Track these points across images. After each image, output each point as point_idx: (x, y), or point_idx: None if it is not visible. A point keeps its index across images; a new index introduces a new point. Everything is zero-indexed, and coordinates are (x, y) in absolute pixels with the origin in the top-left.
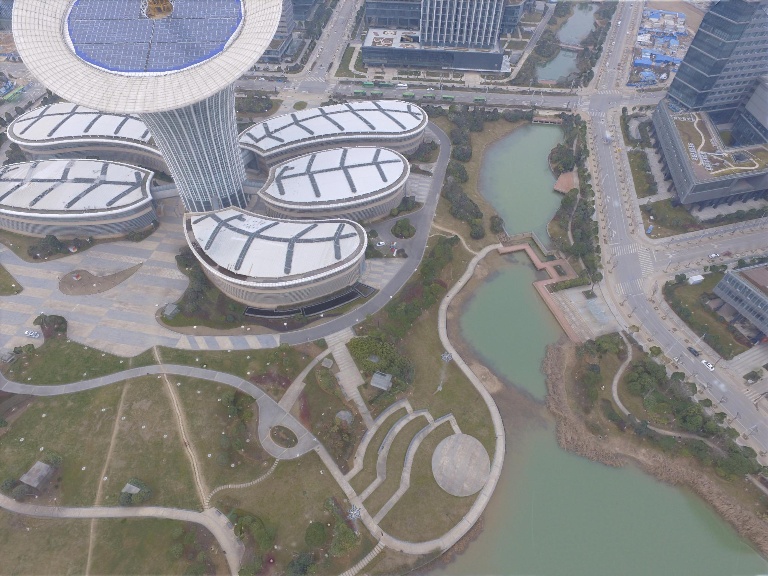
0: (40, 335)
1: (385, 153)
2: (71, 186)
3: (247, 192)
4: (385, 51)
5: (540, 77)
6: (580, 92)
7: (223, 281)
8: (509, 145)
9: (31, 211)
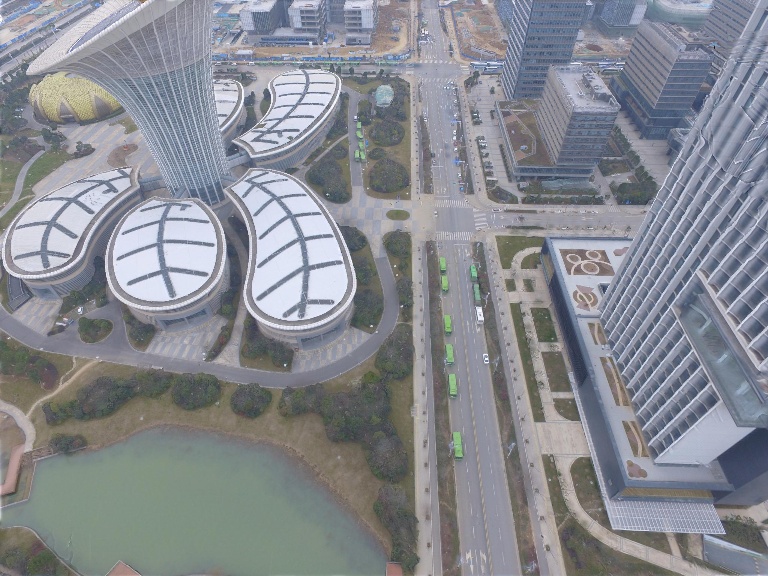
0: (78, 151)
1: (193, 280)
2: None
3: None
4: None
5: None
6: None
7: None
8: (292, 494)
9: None
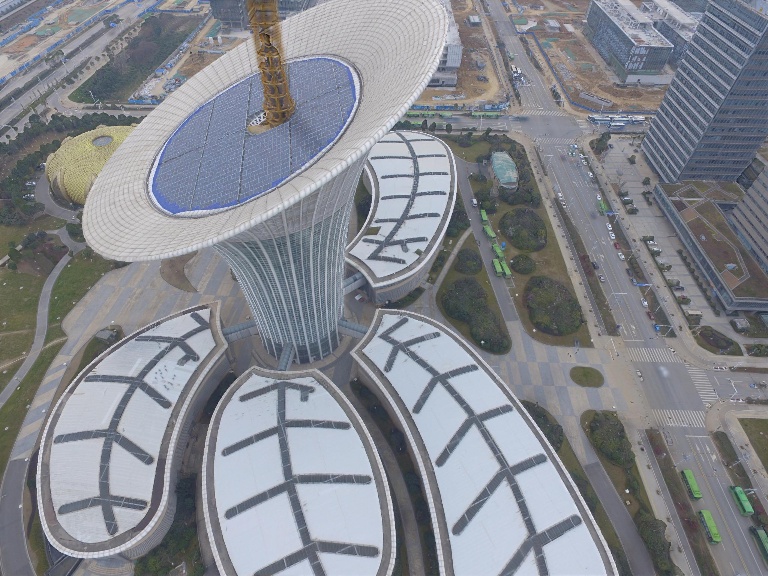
0: None
1: (359, 568)
2: None
3: None
4: None
5: None
6: None
7: None
8: None
9: None
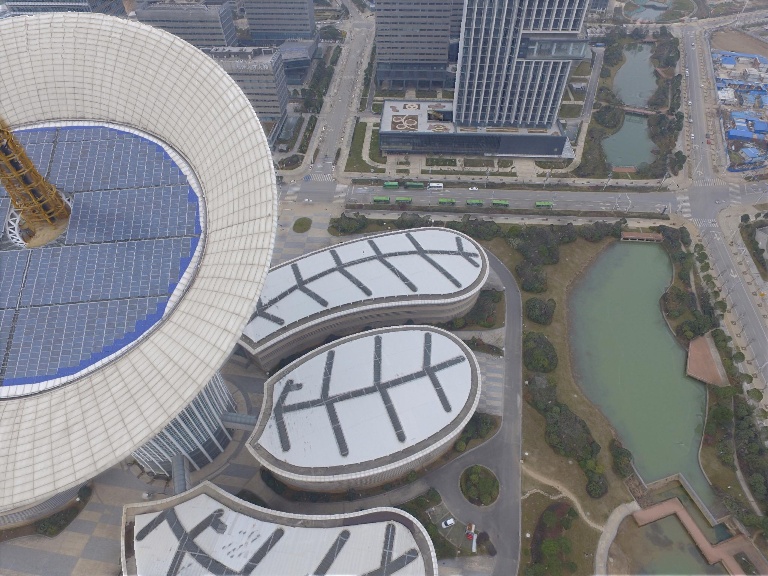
0: None
1: (439, 343)
2: None
3: (230, 427)
4: (409, 136)
5: (612, 161)
6: (671, 185)
7: None
8: (599, 284)
9: None
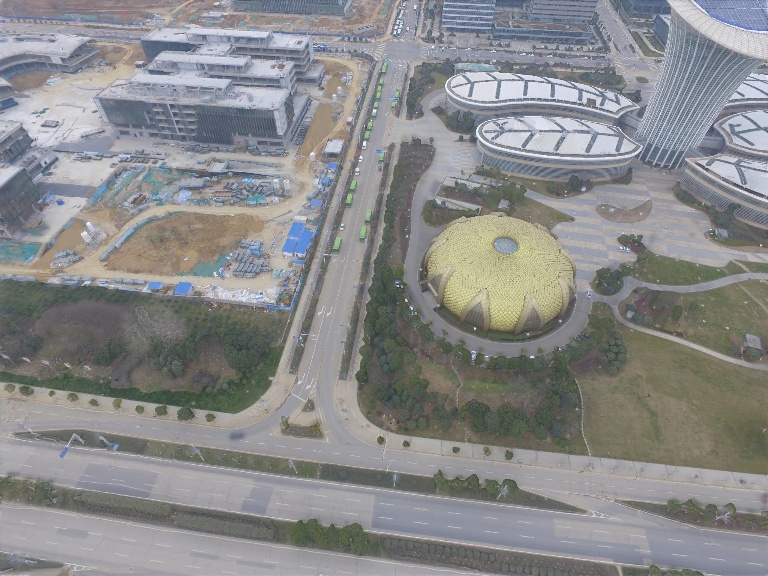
0: None
1: None
2: (577, 136)
3: (700, 145)
4: None
5: None
6: None
7: (760, 211)
8: None
9: (556, 155)
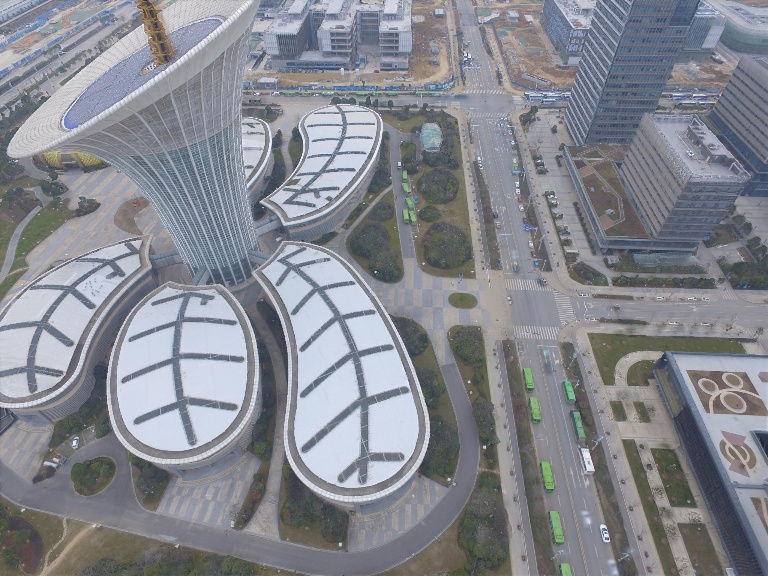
0: None
1: (218, 417)
2: None
3: None
4: None
5: None
6: None
7: None
8: None
9: None
